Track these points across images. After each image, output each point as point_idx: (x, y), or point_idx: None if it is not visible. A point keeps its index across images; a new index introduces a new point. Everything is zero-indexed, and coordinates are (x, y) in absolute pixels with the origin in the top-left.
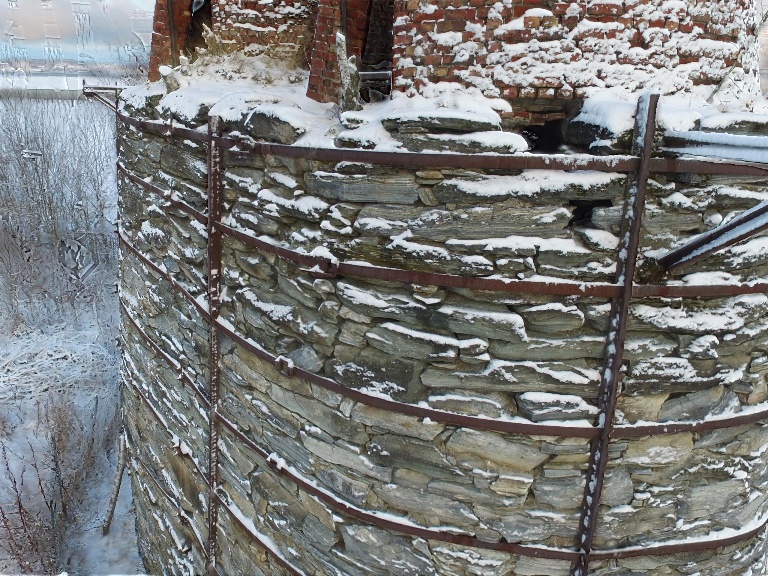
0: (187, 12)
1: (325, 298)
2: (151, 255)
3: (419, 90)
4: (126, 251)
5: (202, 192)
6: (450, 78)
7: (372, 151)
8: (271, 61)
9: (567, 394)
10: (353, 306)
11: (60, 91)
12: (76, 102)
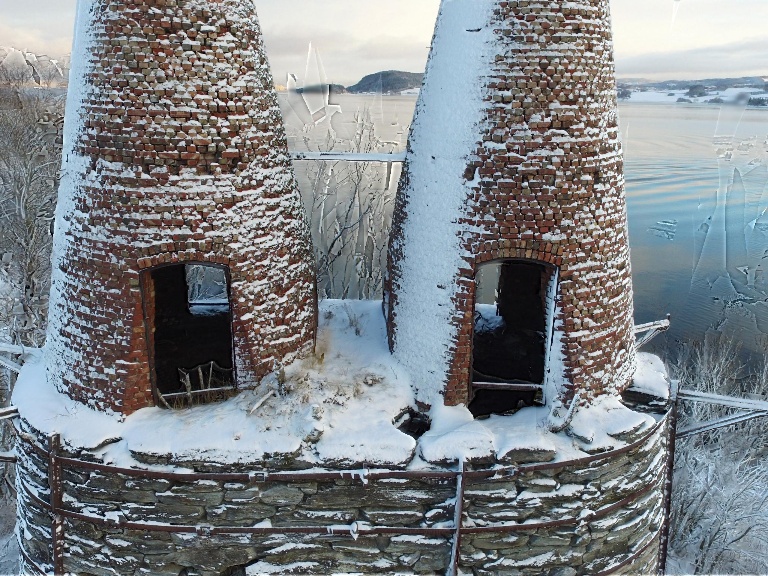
0: (153, 329)
1: (581, 535)
2: None
3: (591, 403)
4: None
5: (416, 512)
6: (602, 393)
7: (614, 451)
8: (322, 367)
9: (660, 510)
10: (603, 530)
11: None
12: None
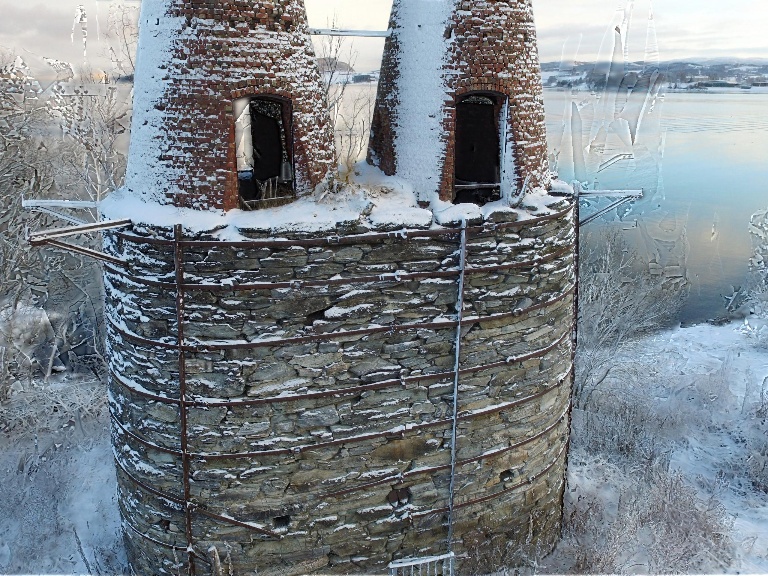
0: None
1: None
2: (346, 328)
3: None
4: (269, 351)
5: None
6: None
7: None
8: None
9: None
10: None
11: None
12: None
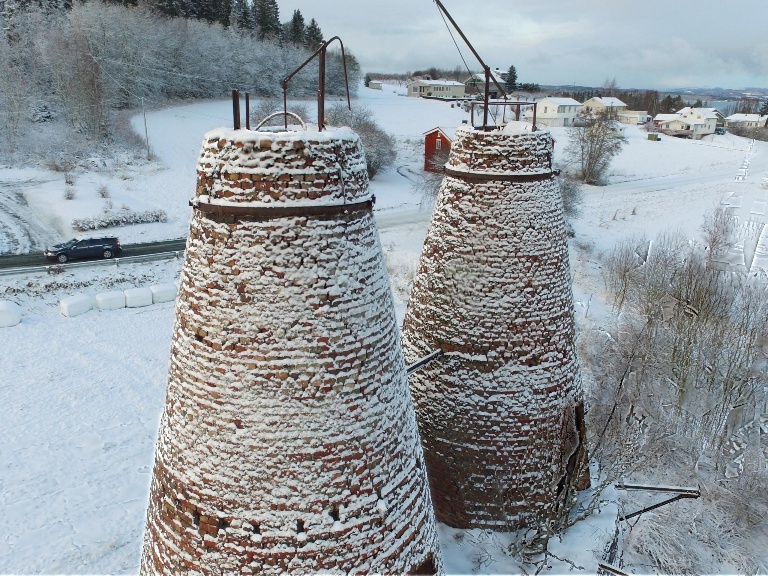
0: None
1: None
2: None
3: None
4: None
5: None
6: None
7: None
8: None
9: None
10: None
11: (736, 265)
12: (760, 273)
